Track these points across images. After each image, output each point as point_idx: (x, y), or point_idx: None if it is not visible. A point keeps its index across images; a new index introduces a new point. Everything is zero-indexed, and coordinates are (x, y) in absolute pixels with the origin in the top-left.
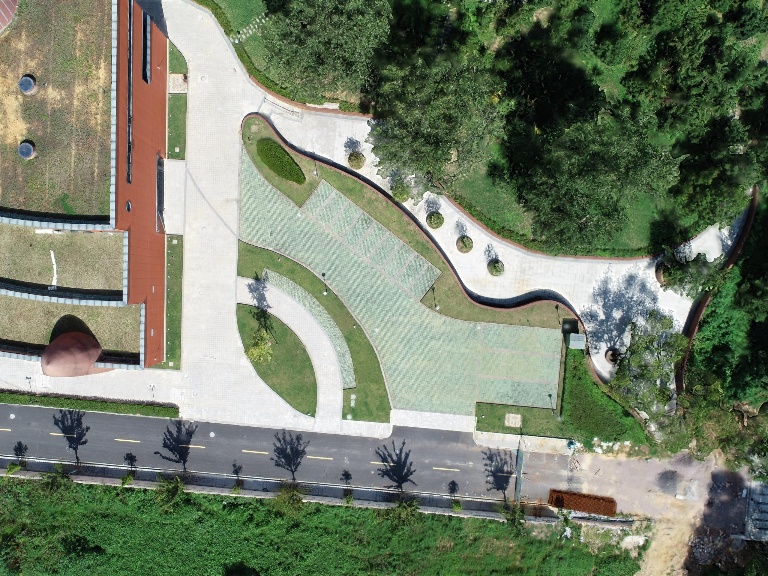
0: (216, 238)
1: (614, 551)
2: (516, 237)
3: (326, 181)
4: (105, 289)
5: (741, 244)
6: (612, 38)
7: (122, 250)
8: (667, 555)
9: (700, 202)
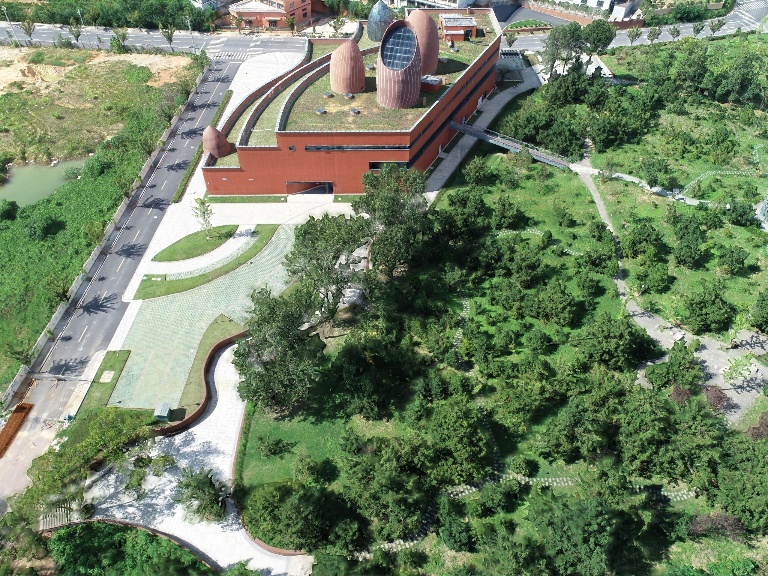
0: (283, 215)
1: None
2: None
3: None
4: None
5: None
6: (427, 412)
7: None
8: None
9: None
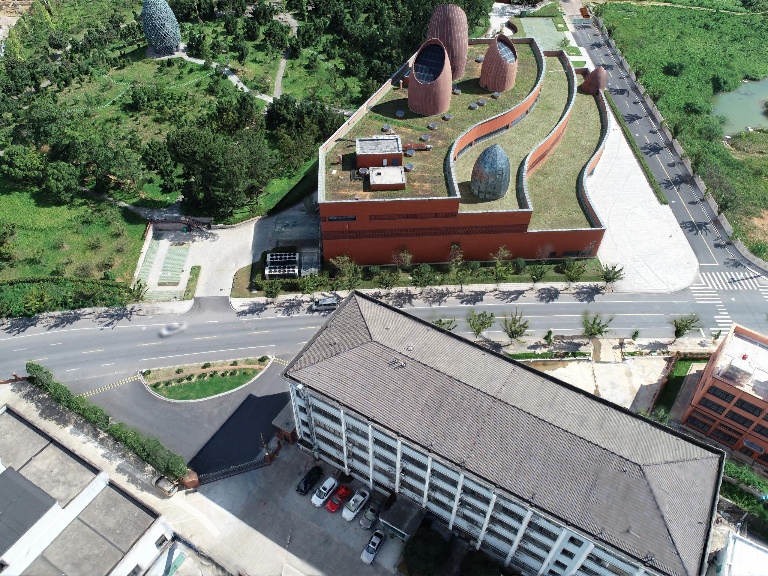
0: None
1: None
2: None
3: None
4: None
5: None
6: None
7: None
8: (594, 0)
9: None
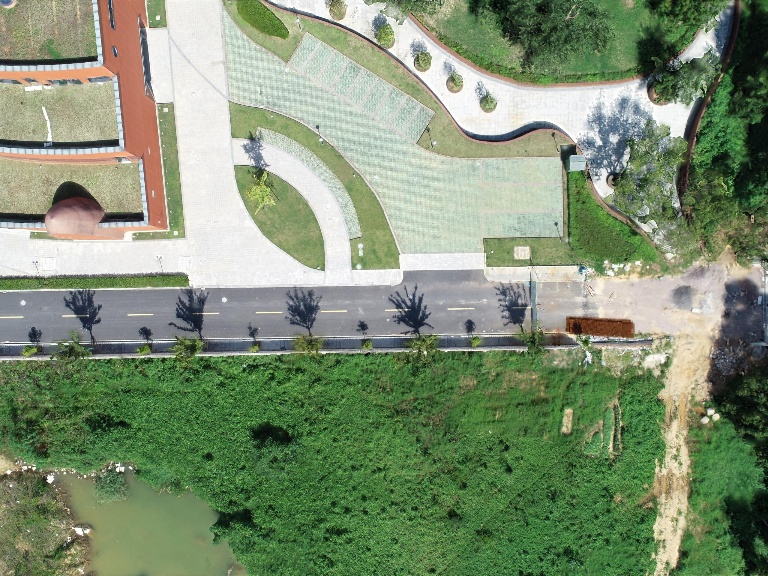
0: (206, 102)
1: (637, 372)
2: (505, 71)
3: (310, 33)
4: (101, 140)
5: (729, 52)
6: None
7: (113, 99)
8: (690, 370)
9: (684, 2)
